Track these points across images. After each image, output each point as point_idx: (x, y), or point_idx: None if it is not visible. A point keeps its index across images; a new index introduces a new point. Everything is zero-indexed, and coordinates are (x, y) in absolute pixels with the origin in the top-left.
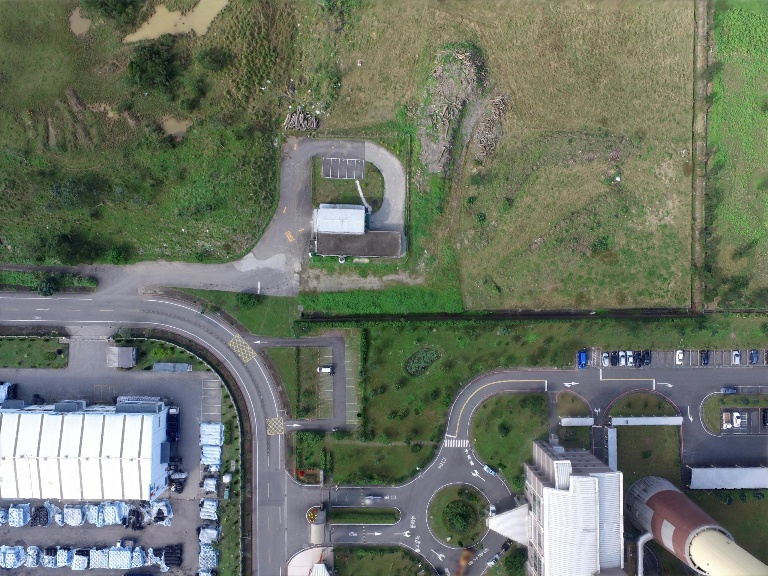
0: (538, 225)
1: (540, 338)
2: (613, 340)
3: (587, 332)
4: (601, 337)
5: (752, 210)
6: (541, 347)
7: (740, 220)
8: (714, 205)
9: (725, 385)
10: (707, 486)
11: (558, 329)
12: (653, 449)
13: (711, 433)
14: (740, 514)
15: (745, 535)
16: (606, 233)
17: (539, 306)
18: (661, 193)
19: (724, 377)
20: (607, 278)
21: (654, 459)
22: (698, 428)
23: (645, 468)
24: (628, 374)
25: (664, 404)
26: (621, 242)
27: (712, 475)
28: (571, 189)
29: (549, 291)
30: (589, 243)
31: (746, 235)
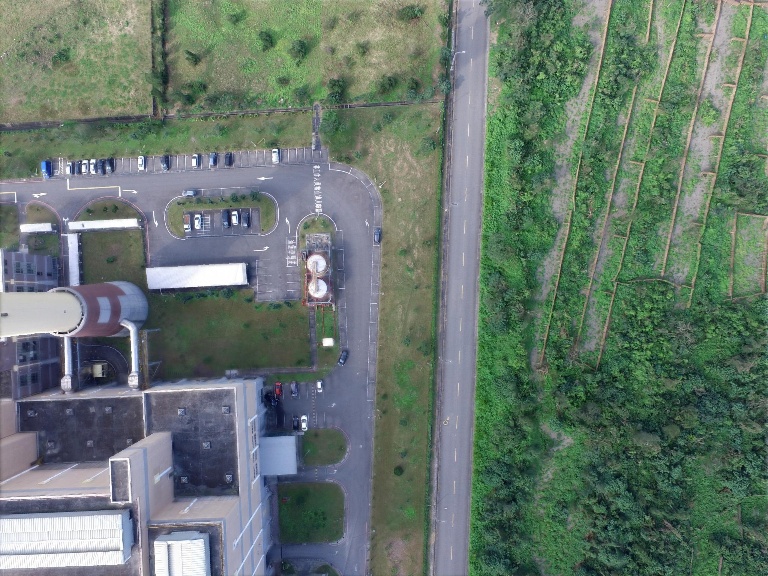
0: (3, 41)
1: (8, 151)
2: (78, 150)
3: (52, 143)
4: (66, 147)
5: (209, 15)
6: (9, 160)
7: (197, 26)
8: (157, 8)
9: (188, 189)
10: (164, 285)
11: (23, 141)
12: (119, 254)
13: (176, 236)
14: (205, 314)
15: (210, 334)
16: (67, 45)
17: (7, 120)
18: (120, 3)
19: (187, 181)
20: (69, 89)
21: (120, 264)
22: (163, 232)
23: (112, 273)
24: (94, 182)
25: (129, 210)
26: (81, 53)
27: (166, 274)
28: (33, 4)
29: (13, 104)
30: (51, 56)
31: (203, 40)
